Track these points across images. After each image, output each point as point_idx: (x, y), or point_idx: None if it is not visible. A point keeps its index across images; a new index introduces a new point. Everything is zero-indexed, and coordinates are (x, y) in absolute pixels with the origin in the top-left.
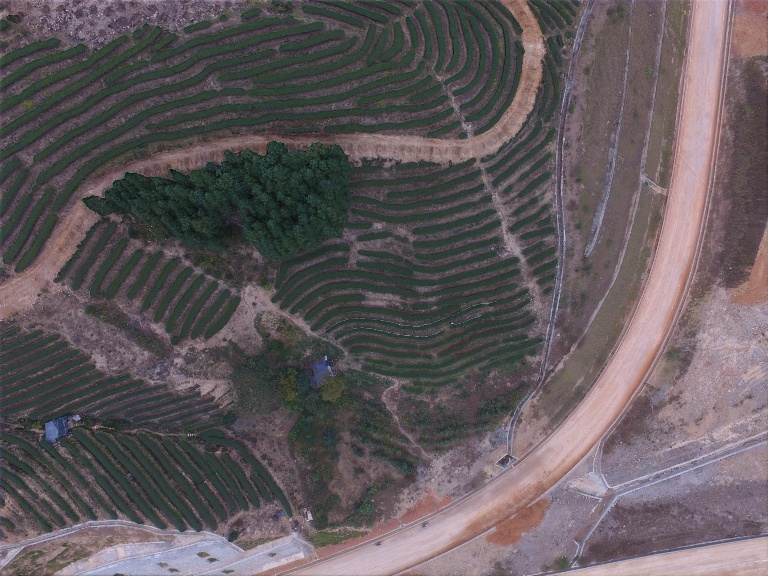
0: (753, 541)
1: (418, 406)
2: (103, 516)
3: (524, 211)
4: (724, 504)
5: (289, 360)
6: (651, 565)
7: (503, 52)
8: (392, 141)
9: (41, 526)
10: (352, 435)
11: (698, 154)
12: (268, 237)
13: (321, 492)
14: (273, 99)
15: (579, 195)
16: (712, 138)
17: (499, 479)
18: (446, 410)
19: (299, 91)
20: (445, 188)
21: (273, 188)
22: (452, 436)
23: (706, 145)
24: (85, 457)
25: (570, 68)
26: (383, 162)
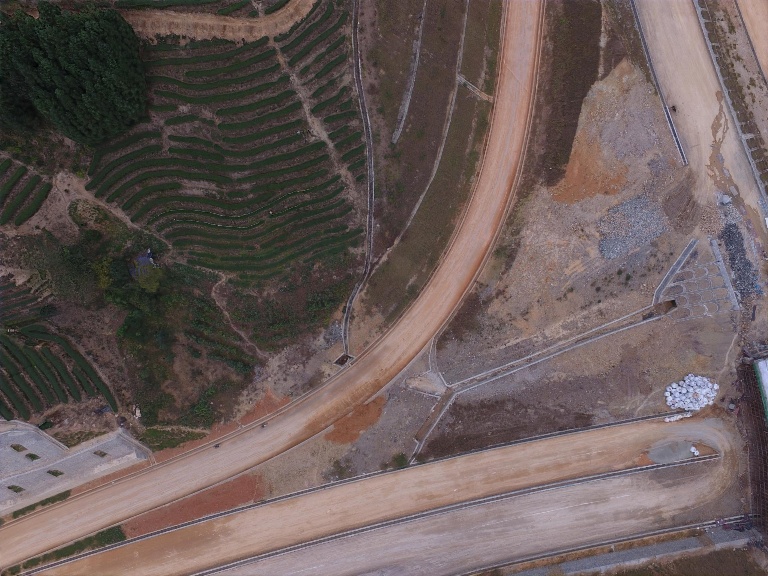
0: (585, 433)
1: (246, 300)
2: None
3: (324, 93)
4: (556, 398)
5: (110, 252)
6: (488, 460)
7: None
8: (185, 19)
9: None
10: (185, 334)
11: (522, 64)
12: (58, 108)
13: (151, 389)
14: None
15: (378, 80)
16: (534, 49)
17: (337, 378)
18: (274, 304)
19: None
20: (241, 67)
21: (54, 54)
22: (284, 332)
23: (529, 56)
24: None
25: None
26: (178, 40)
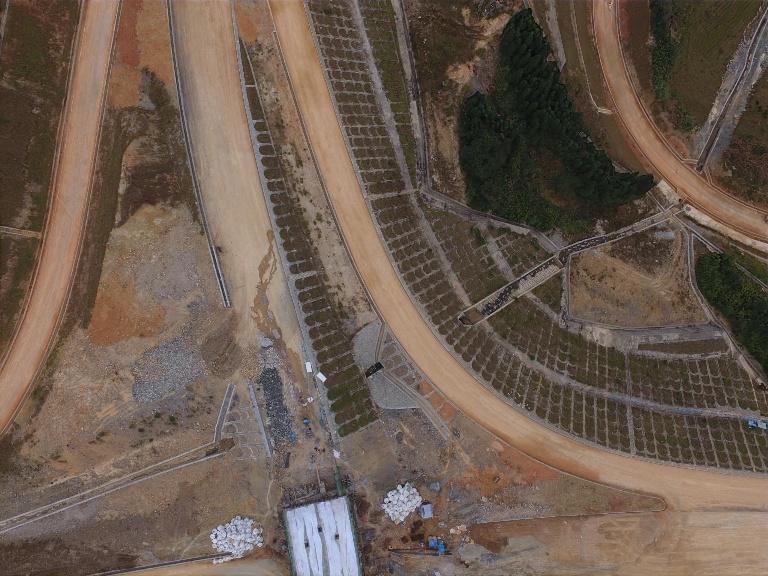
0: (131, 574)
1: None
2: None
3: None
4: (99, 538)
5: None
6: None
7: None
8: None
9: None
10: None
11: (75, 199)
12: None
13: None
14: None
15: None
16: (88, 184)
17: None
18: None
19: None
20: None
21: None
22: None
23: (83, 191)
24: None
25: None
26: None
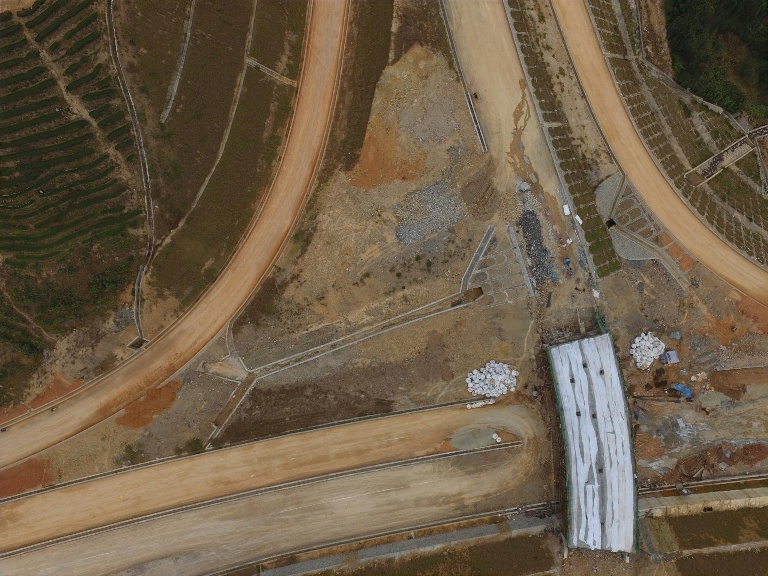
0: (386, 420)
1: (25, 281)
2: None
3: (78, 70)
4: (356, 383)
5: None
6: (287, 446)
7: None
8: None
9: None
10: None
11: (328, 50)
12: None
13: None
14: None
15: (138, 58)
16: (341, 35)
17: (131, 362)
18: (53, 285)
19: None
20: None
21: None
22: (68, 314)
23: (335, 41)
24: None
25: None
26: None
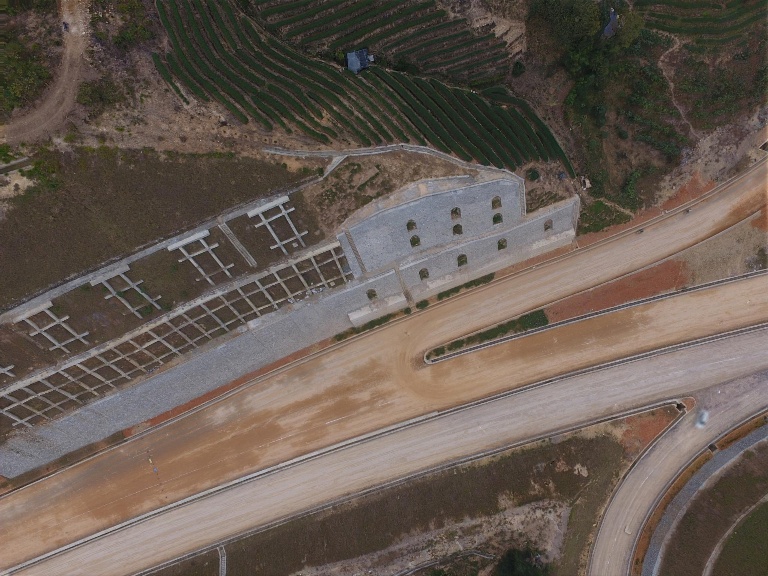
0: None
1: (698, 68)
2: (413, 141)
3: None
4: None
5: None
6: None
7: None
8: None
9: (359, 141)
10: (622, 110)
11: None
12: None
13: (596, 161)
14: None
15: None
16: None
17: (762, 164)
18: (727, 72)
19: None
20: None
21: None
22: (726, 106)
23: None
24: (387, 89)
25: None
26: None
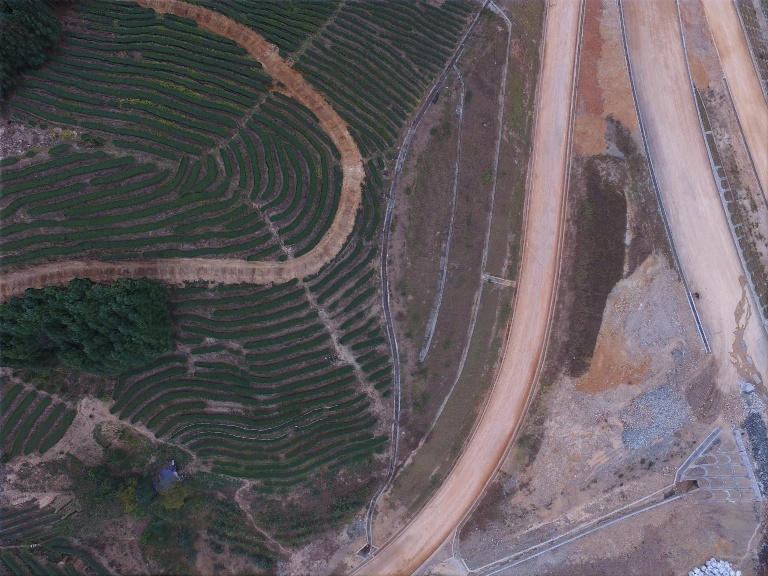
0: None
1: (270, 505)
2: None
3: (352, 324)
4: None
5: (134, 467)
6: None
7: (321, 177)
8: (214, 264)
9: None
10: (208, 534)
11: (545, 247)
12: (86, 362)
13: None
14: (88, 228)
15: (407, 307)
16: (557, 232)
17: (360, 569)
18: (298, 508)
19: (112, 221)
20: (270, 307)
21: (83, 319)
22: (307, 532)
23: (552, 239)
24: None
25: (392, 188)
26: (206, 283)
